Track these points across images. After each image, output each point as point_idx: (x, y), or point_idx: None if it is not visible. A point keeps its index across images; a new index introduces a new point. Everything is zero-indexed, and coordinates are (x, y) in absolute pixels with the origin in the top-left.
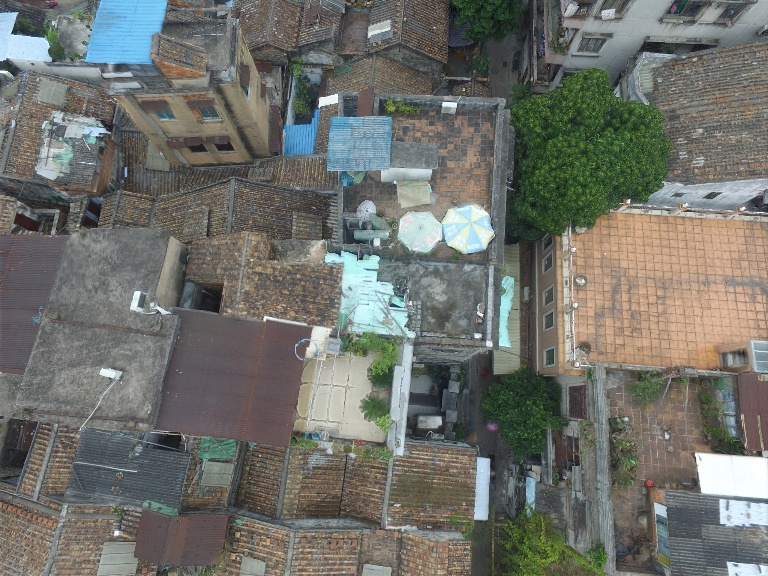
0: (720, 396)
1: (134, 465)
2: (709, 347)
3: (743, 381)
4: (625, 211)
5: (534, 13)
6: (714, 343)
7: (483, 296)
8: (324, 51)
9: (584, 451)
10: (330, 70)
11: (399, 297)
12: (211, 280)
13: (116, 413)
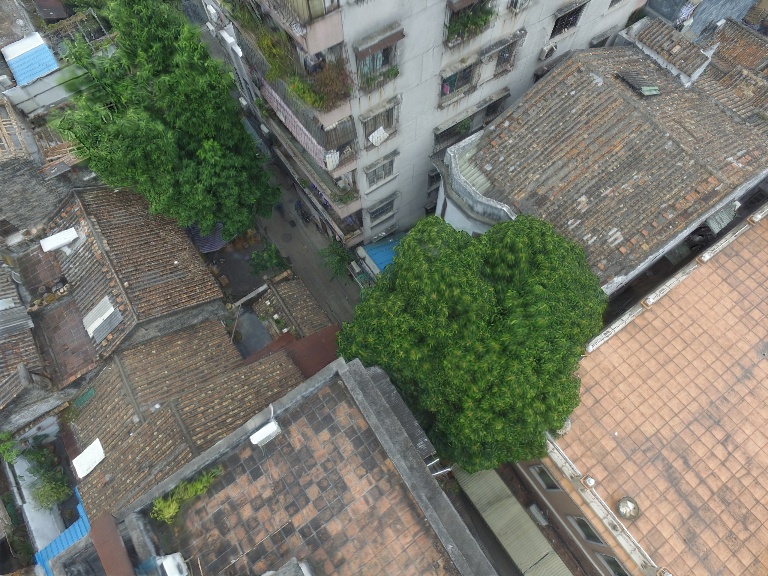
0: None
1: None
2: None
3: None
4: None
5: (285, 164)
6: None
7: None
8: (32, 403)
9: None
10: (65, 410)
11: None
12: None
13: None
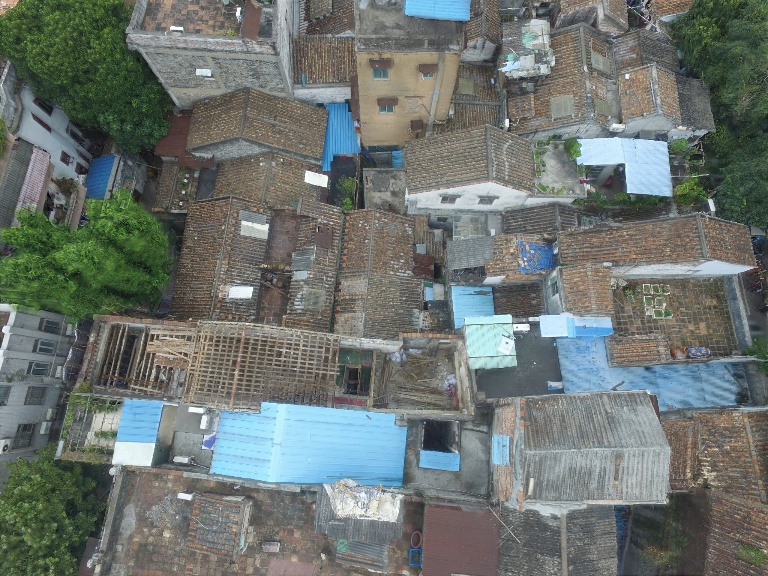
0: None
1: None
2: None
3: None
4: None
5: None
6: None
7: None
8: None
9: None
10: None
11: None
12: None
13: None
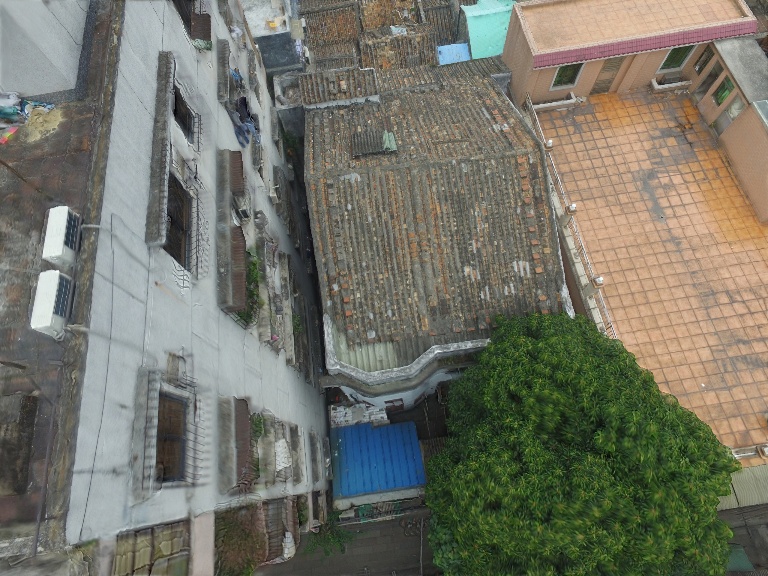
0: None
1: None
2: None
3: None
4: None
5: None
6: (759, 226)
7: None
8: None
9: None
10: None
11: None
12: None
13: None
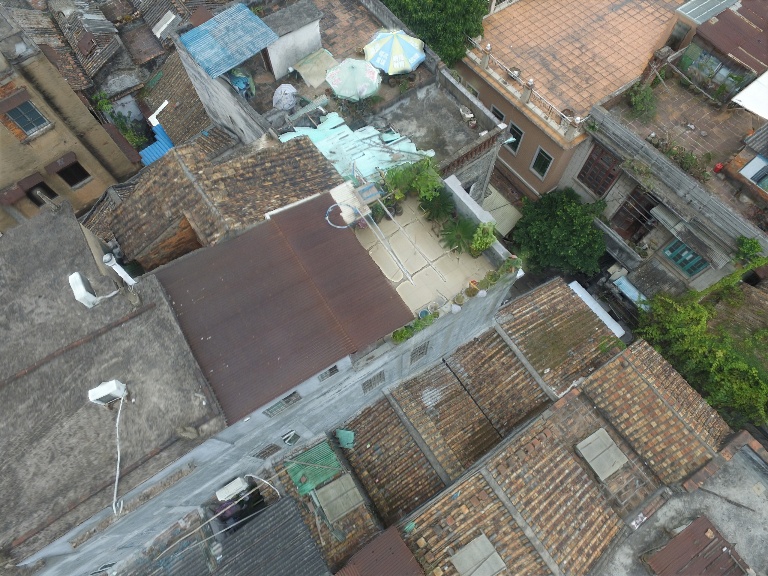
0: (695, 69)
1: (225, 574)
2: (648, 55)
3: (704, 31)
4: (496, 10)
5: None
6: (648, 50)
7: (456, 105)
8: (122, 69)
9: (649, 184)
10: (141, 90)
11: (387, 133)
12: (165, 237)
13: (155, 441)
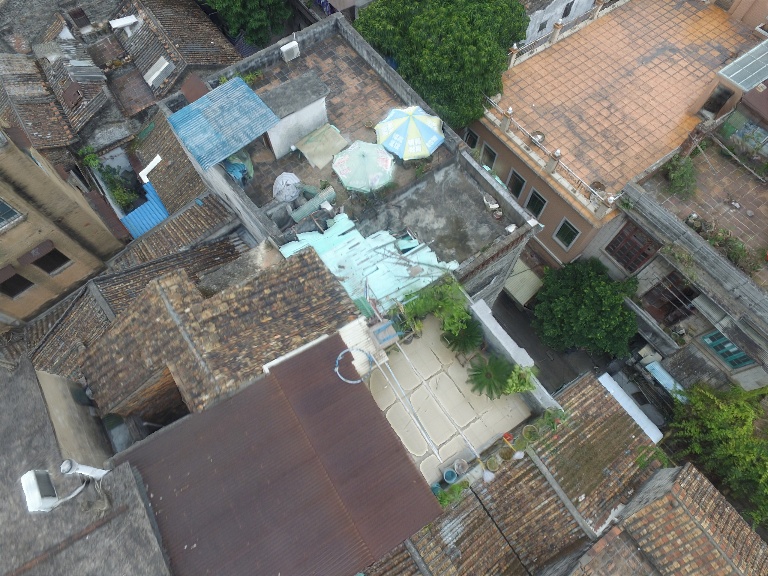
0: (739, 138)
1: None
2: (683, 117)
3: (752, 101)
4: (516, 63)
5: None
6: (683, 111)
7: (479, 191)
8: (110, 122)
9: (692, 274)
10: (131, 142)
11: (403, 239)
12: (145, 387)
13: None
